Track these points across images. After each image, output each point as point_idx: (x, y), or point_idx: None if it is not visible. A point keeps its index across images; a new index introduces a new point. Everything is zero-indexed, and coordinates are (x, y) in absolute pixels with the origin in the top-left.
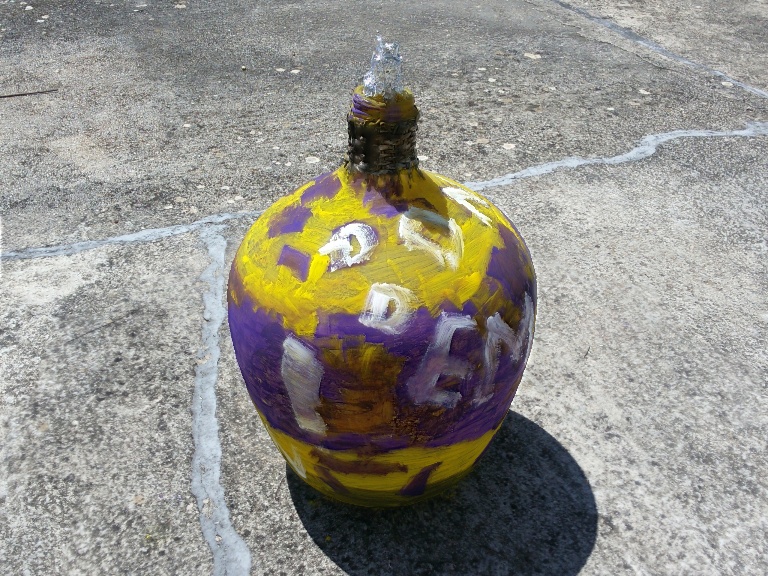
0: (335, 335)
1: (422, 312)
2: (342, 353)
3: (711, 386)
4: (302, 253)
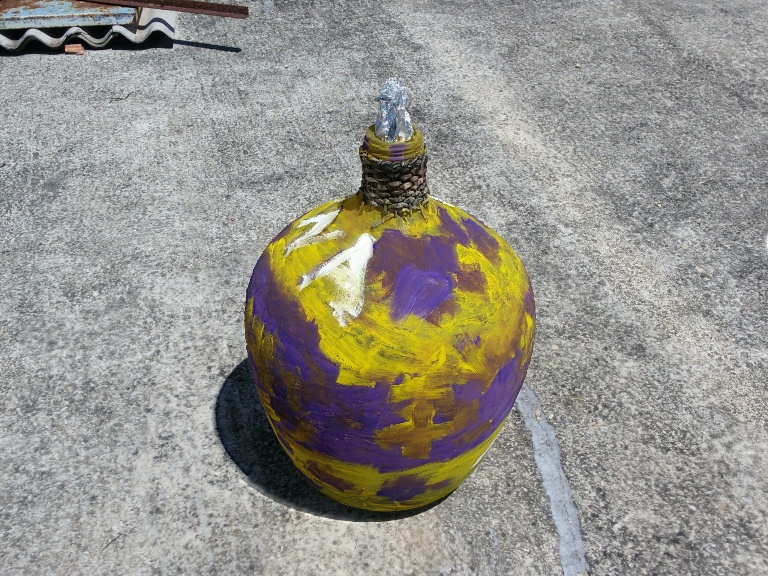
0: None
1: None
2: None
3: (16, 482)
4: None
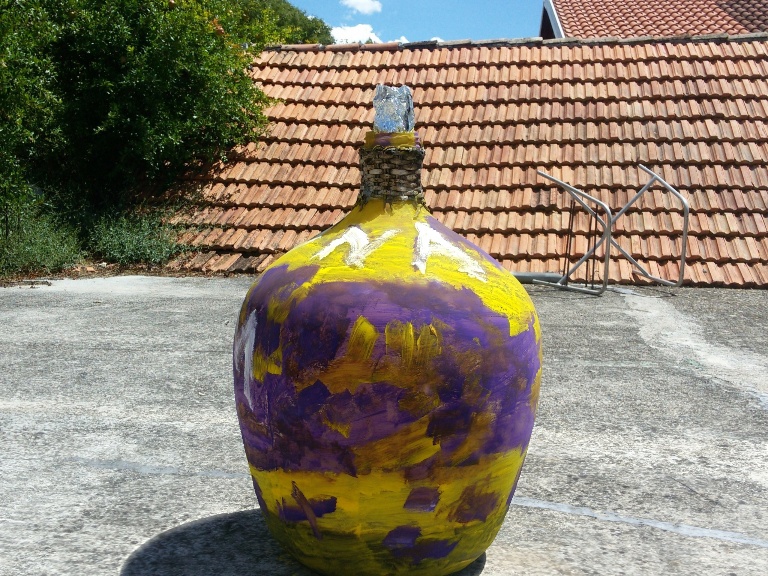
0: None
1: None
2: None
3: None
4: None
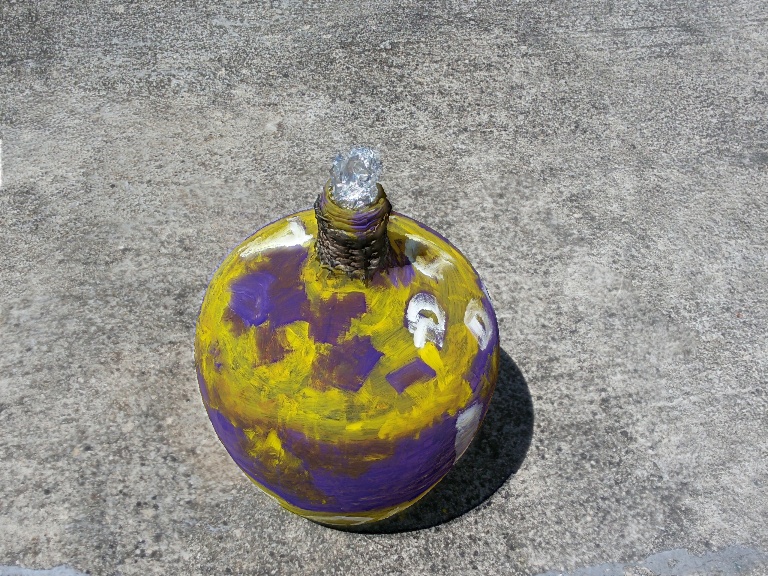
0: (481, 376)
1: (484, 303)
2: (487, 381)
3: None
4: (410, 363)
